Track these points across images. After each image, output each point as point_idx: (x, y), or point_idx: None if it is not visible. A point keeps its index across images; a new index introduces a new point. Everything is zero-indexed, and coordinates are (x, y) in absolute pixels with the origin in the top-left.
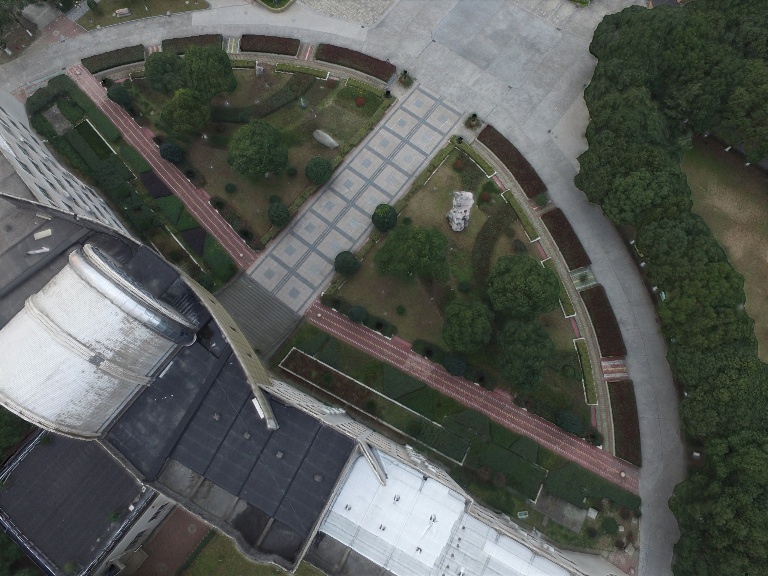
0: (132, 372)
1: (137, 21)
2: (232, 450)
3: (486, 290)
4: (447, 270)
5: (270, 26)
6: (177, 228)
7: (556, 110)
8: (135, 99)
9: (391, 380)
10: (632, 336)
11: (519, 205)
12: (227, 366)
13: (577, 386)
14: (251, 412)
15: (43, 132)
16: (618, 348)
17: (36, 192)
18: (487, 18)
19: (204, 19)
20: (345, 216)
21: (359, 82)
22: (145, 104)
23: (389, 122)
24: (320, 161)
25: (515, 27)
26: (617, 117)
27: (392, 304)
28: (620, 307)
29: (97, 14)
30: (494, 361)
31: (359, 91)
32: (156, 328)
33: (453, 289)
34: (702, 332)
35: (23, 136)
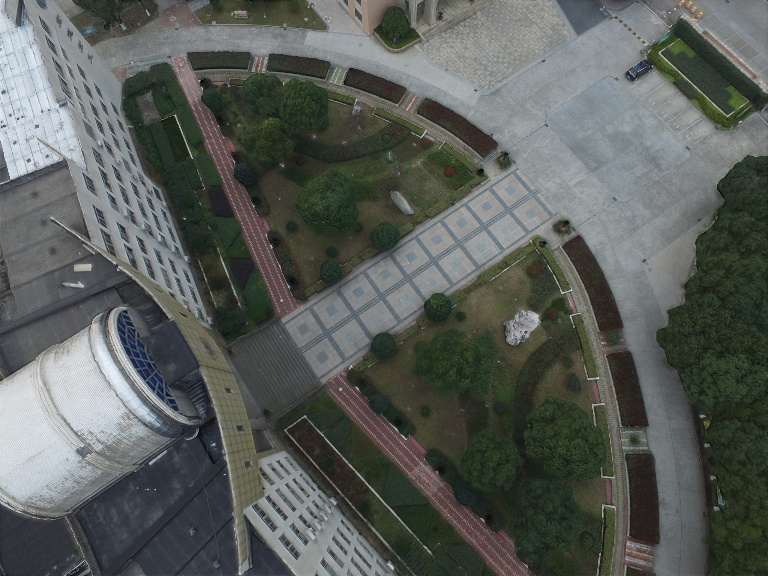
0: (119, 464)
1: (252, 26)
2: (197, 574)
3: (523, 419)
4: (487, 383)
5: (381, 65)
6: (228, 253)
7: (659, 239)
8: (227, 106)
9: (393, 485)
10: (671, 523)
11: (586, 334)
12: (220, 476)
13: (592, 559)
14: (229, 537)
15: (131, 117)
16: (651, 533)
17: (89, 221)
18: (612, 115)
19: (318, 41)
20: (398, 290)
21: (454, 150)
22: (235, 114)
23: (473, 201)
24: (389, 229)
25: (640, 133)
26: (729, 285)
27: (419, 401)
28: (666, 485)
29: (216, 10)
30: (509, 501)
31: (452, 160)
32: (156, 428)
33: (488, 406)
34: (758, 573)
35: (109, 123)
